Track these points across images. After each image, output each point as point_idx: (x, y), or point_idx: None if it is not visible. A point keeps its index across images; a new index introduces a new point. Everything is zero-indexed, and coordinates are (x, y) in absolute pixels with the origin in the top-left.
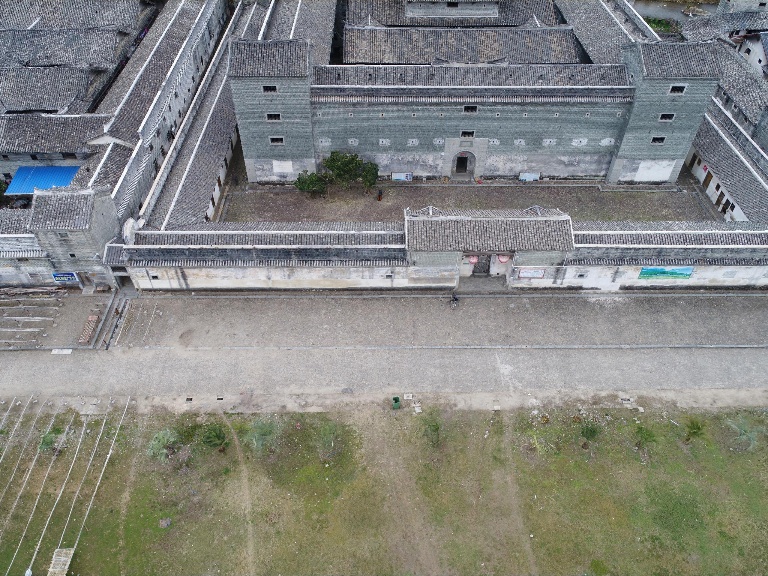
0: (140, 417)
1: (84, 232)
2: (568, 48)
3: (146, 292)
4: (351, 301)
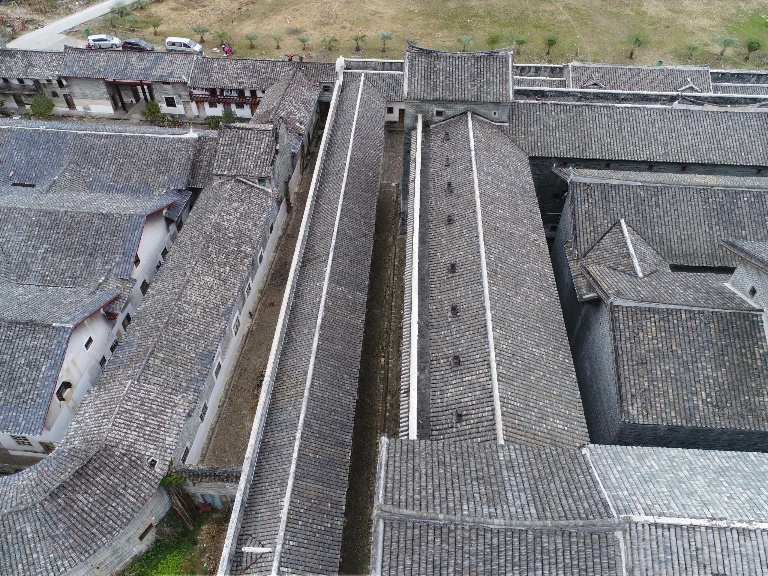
0: None
1: None
2: None
3: None
4: None
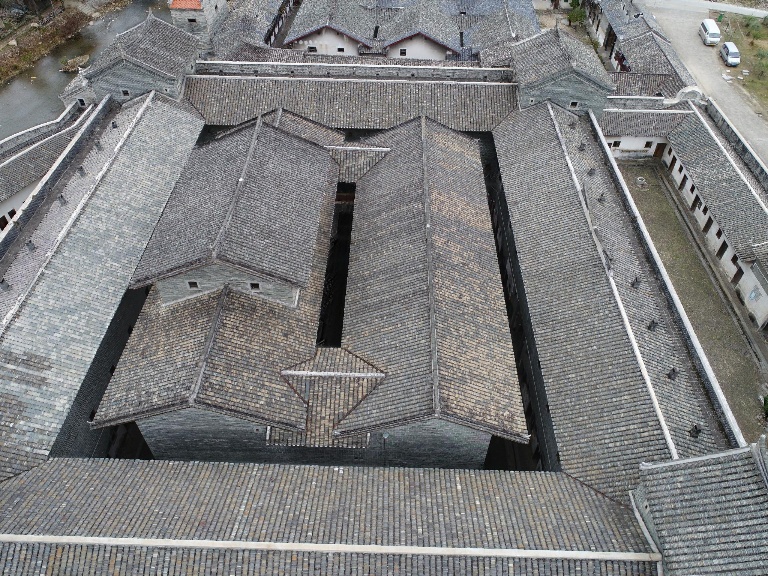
0: None
1: None
2: (456, 138)
3: None
4: None
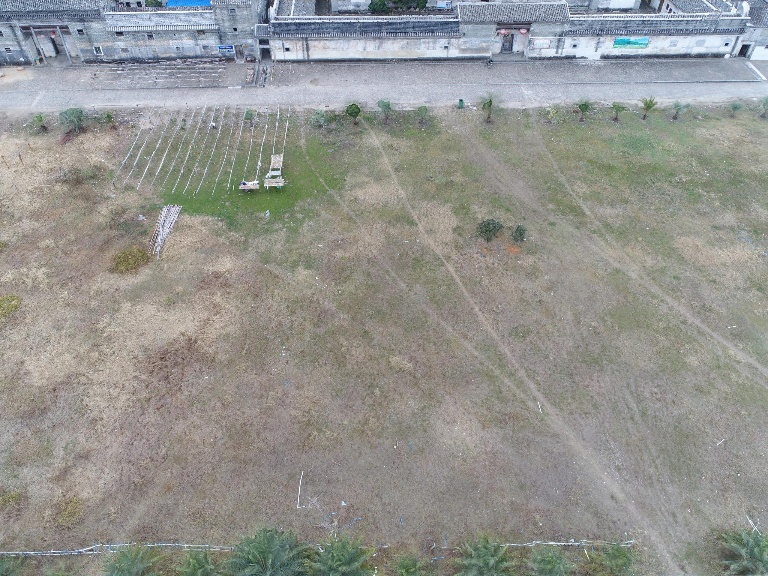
0: (298, 113)
1: (247, 8)
2: None
3: (279, 63)
4: (420, 66)
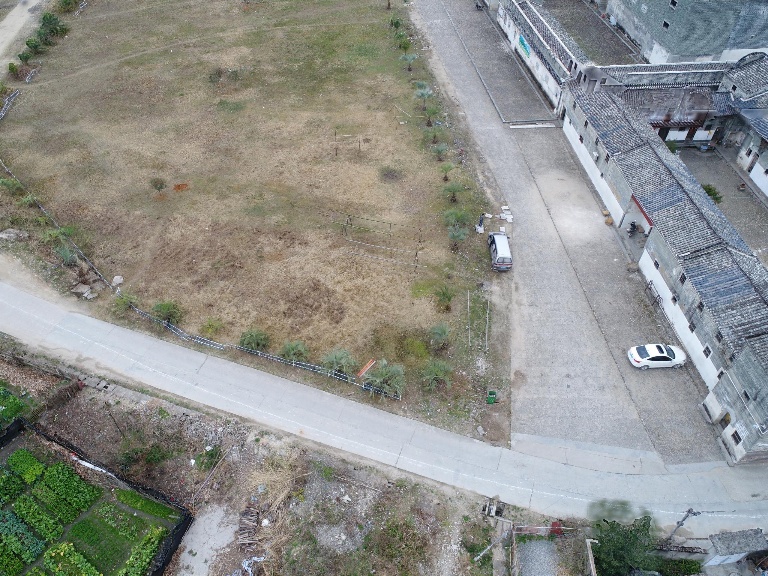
0: None
1: None
2: None
3: None
4: None
